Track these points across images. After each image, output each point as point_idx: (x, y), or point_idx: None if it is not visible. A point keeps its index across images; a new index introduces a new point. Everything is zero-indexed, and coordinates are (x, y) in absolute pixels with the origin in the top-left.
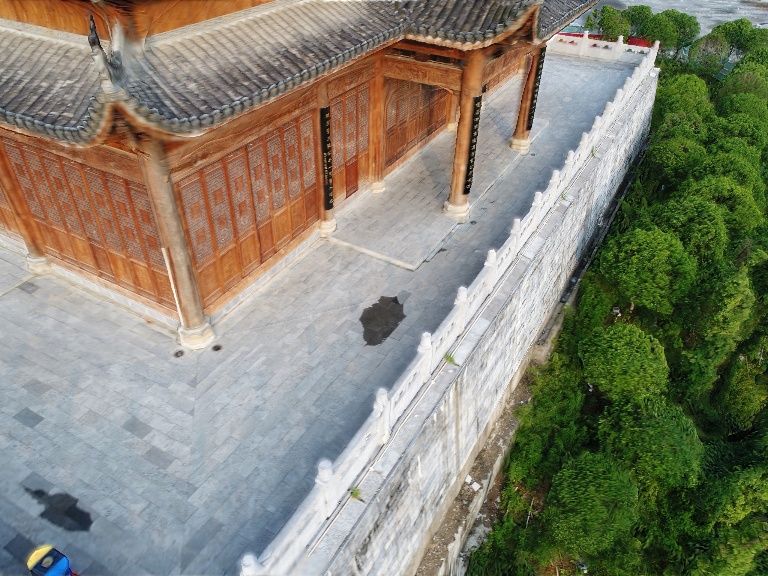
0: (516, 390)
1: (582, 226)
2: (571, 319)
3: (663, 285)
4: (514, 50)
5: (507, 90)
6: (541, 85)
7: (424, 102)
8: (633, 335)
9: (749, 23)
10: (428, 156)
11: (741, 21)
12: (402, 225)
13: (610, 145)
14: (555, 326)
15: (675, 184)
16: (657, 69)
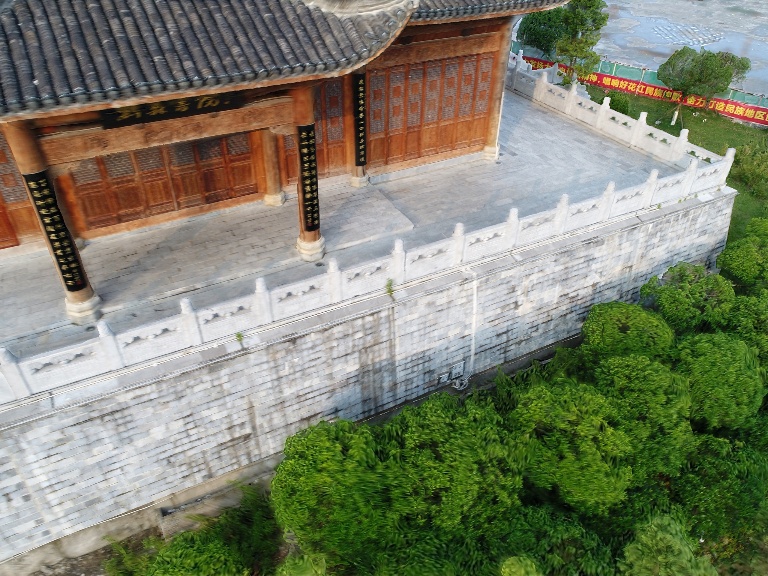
0: (86, 556)
1: (349, 382)
2: (251, 500)
3: None
4: (182, 122)
5: (445, 169)
6: (502, 173)
7: (181, 162)
8: (187, 573)
9: None
10: (190, 227)
11: None
12: (9, 302)
13: (452, 284)
14: (212, 499)
15: (591, 373)
16: (728, 191)
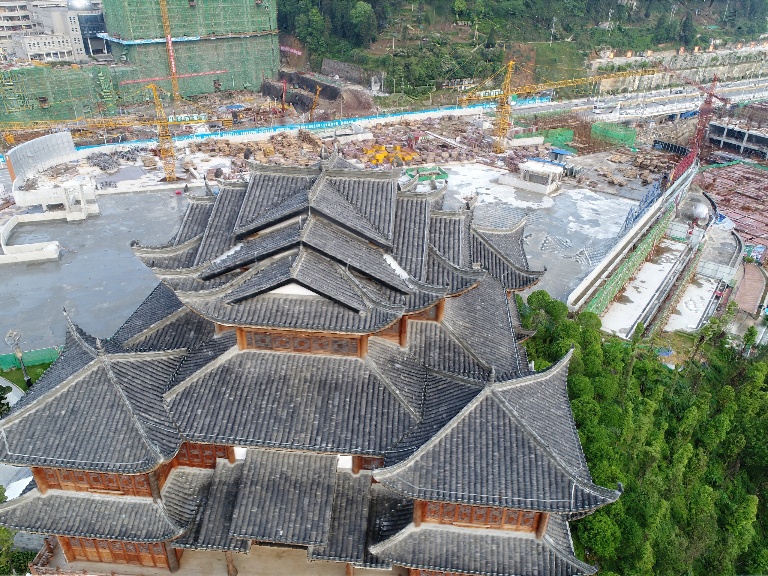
0: None
1: None
2: None
3: (612, 547)
4: None
5: None
6: None
7: None
8: None
9: (547, 294)
10: None
11: (542, 293)
12: None
13: None
14: None
15: None
16: None
